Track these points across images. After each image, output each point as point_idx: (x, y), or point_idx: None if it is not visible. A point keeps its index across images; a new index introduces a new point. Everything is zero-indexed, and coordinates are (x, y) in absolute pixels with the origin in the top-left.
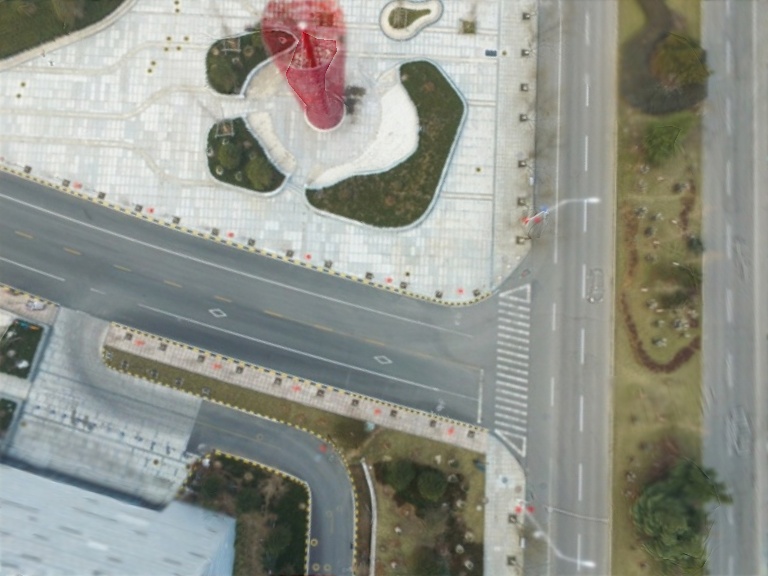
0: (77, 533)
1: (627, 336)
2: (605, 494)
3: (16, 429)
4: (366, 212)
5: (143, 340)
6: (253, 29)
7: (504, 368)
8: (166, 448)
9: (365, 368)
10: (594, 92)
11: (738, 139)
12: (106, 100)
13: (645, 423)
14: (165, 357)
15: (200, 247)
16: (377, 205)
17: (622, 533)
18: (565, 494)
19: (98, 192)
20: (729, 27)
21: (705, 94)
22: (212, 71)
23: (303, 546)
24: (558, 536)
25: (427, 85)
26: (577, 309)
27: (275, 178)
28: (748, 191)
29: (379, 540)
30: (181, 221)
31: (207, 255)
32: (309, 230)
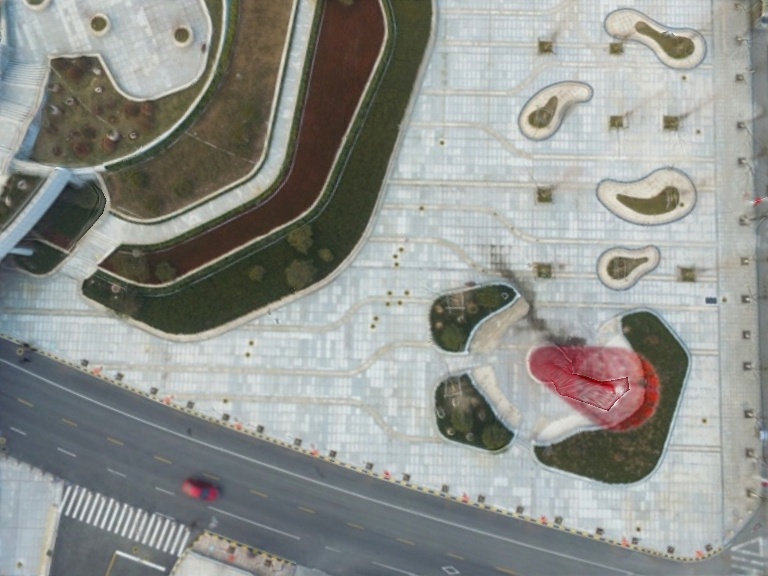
0: None
1: None
2: None
3: None
4: (595, 469)
5: None
6: (473, 283)
7: None
8: None
9: None
10: None
11: None
12: (332, 357)
13: None
14: None
15: (430, 504)
16: (606, 461)
17: None
18: None
19: (329, 450)
20: None
21: None
22: (437, 330)
23: None
24: None
25: (651, 338)
26: None
27: (505, 437)
28: None
29: None
30: (411, 478)
31: (438, 512)
32: (538, 486)
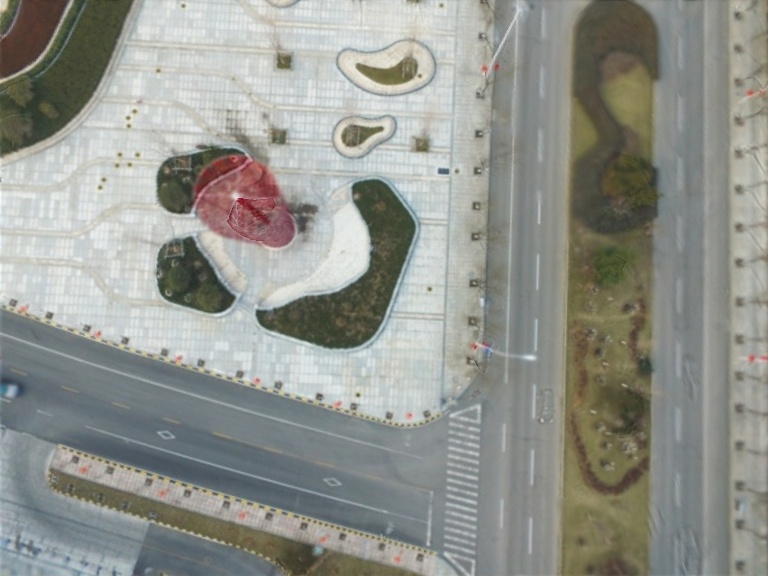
0: None
1: (576, 457)
2: None
3: None
4: (316, 333)
5: (90, 463)
6: (205, 146)
7: (454, 490)
8: (112, 573)
9: (314, 490)
10: (546, 210)
11: (688, 257)
12: (55, 217)
13: (593, 546)
14: (112, 481)
15: (149, 368)
16: (328, 326)
17: None
18: None
19: (46, 312)
20: (680, 144)
21: (654, 215)
22: (162, 190)
23: None
24: None
25: (379, 205)
26: (527, 430)
27: (225, 299)
28: (697, 309)
29: None
30: (130, 341)
31: (156, 376)
32: (259, 350)
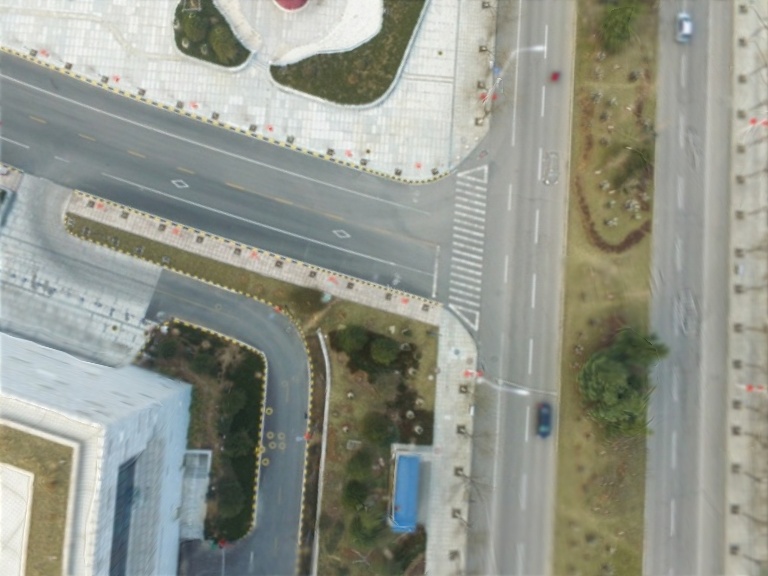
0: (27, 363)
1: (580, 217)
2: (554, 368)
3: None
4: (329, 89)
5: (105, 207)
6: None
7: (460, 245)
8: (125, 315)
9: (324, 241)
10: None
11: (693, 34)
12: None
13: (595, 300)
14: (126, 225)
15: (164, 119)
16: (340, 83)
17: (569, 405)
18: (516, 368)
19: (65, 62)
20: None
21: None
22: None
23: (258, 414)
24: (507, 408)
25: None
26: (532, 190)
27: (240, 53)
28: (701, 84)
29: (332, 406)
30: (146, 93)
31: (171, 127)
32: (272, 106)
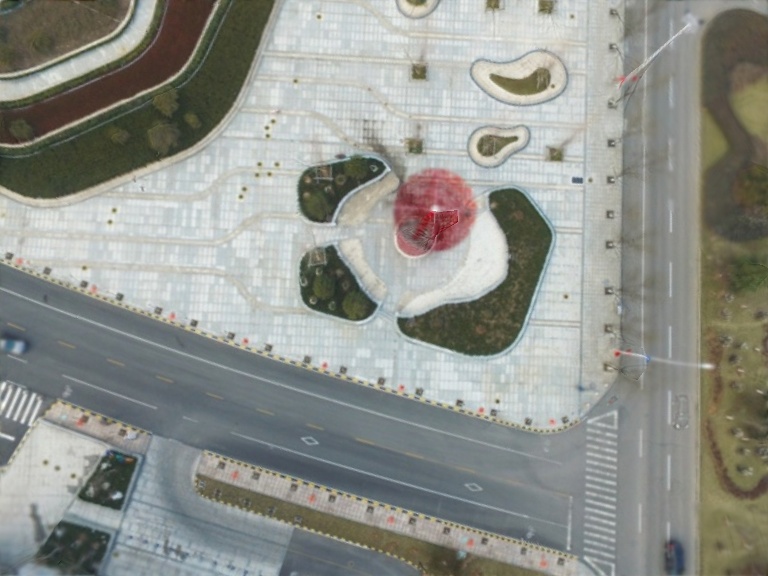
0: None
1: (712, 463)
2: None
3: (109, 560)
4: (457, 340)
5: (236, 469)
6: (344, 156)
7: (592, 495)
8: None
9: (456, 495)
10: (677, 219)
11: None
12: (197, 226)
13: (731, 550)
14: (258, 486)
15: (292, 375)
16: (468, 333)
17: None
18: None
19: (190, 319)
20: None
21: None
22: (304, 199)
23: None
24: None
25: (516, 213)
26: (663, 435)
27: (368, 307)
28: None
29: None
30: (273, 349)
31: (299, 383)
32: (400, 358)
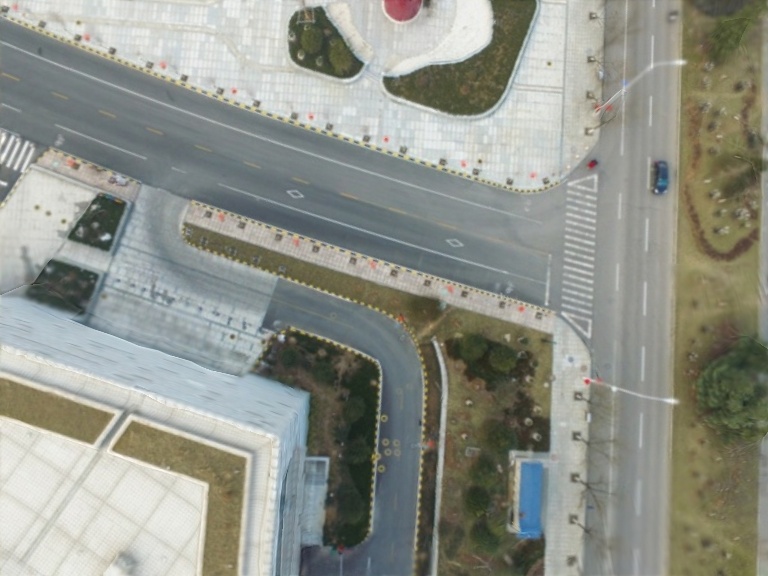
0: (176, 373)
1: (690, 226)
2: (667, 375)
3: (97, 300)
4: (441, 100)
5: (223, 218)
6: None
7: (571, 254)
8: (242, 323)
9: (437, 250)
10: None
11: None
12: None
13: (706, 308)
14: (244, 235)
15: (279, 130)
16: (452, 94)
17: (683, 411)
18: (628, 375)
19: (181, 74)
20: None
21: None
22: None
23: (374, 421)
24: (621, 414)
25: None
26: (642, 199)
27: (354, 64)
28: None
29: (450, 413)
30: (261, 104)
31: (286, 138)
32: (385, 117)
